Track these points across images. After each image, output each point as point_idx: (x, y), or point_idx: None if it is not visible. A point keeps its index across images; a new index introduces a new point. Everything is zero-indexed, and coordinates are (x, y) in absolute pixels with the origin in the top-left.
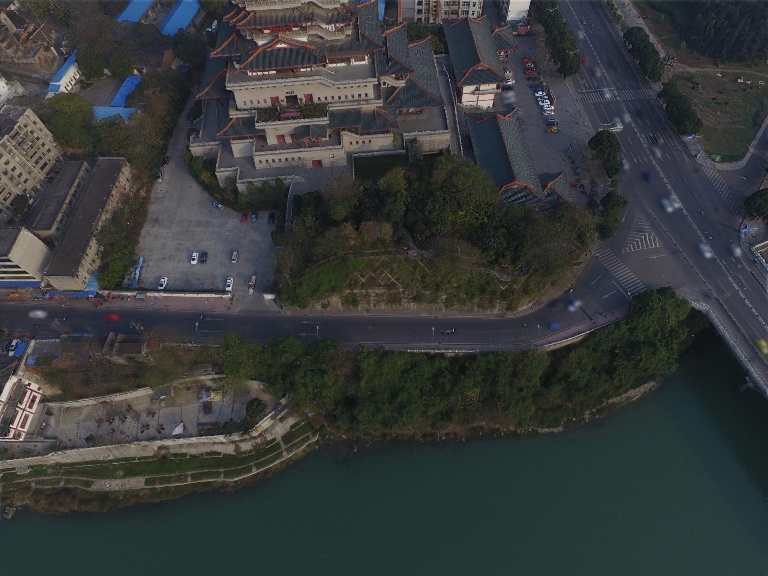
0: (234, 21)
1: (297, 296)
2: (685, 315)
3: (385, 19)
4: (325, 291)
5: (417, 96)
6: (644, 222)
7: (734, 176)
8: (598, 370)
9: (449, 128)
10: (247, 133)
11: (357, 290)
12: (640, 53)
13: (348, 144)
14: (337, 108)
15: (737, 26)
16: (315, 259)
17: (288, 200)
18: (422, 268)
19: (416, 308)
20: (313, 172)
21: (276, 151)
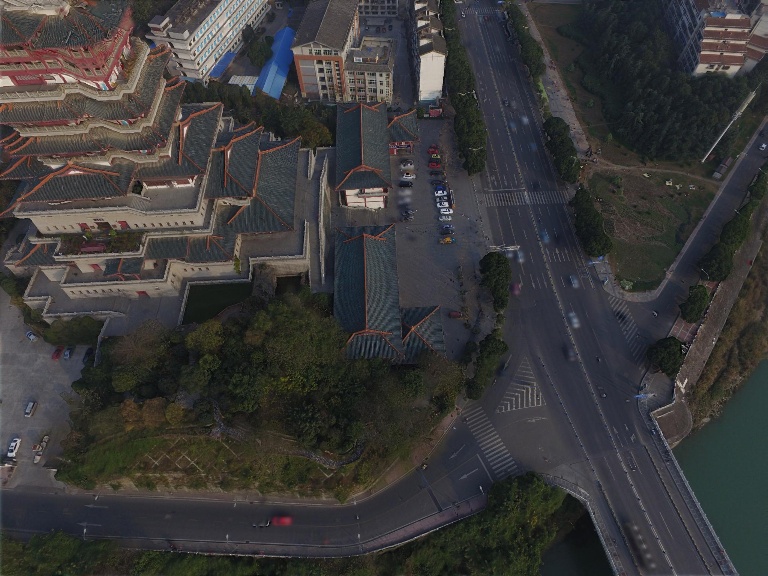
0: (11, 146)
1: (79, 476)
2: (558, 505)
3: (283, 96)
4: (113, 471)
5: (263, 218)
6: (530, 370)
7: (644, 310)
8: (450, 569)
9: (305, 252)
10: (52, 262)
11: (149, 473)
12: (556, 150)
13: (182, 270)
14: (158, 236)
15: (666, 123)
16: (101, 433)
17: (98, 342)
18: (227, 451)
19: (227, 492)
20: (138, 304)
21: (87, 283)
